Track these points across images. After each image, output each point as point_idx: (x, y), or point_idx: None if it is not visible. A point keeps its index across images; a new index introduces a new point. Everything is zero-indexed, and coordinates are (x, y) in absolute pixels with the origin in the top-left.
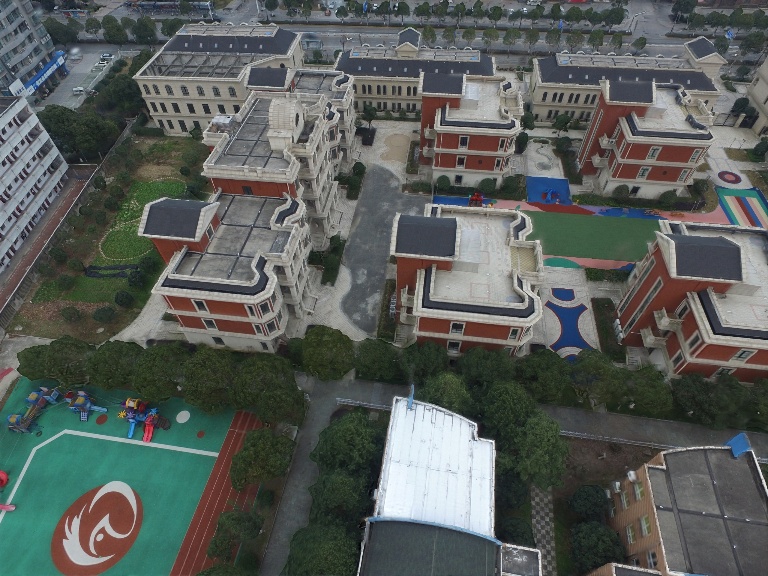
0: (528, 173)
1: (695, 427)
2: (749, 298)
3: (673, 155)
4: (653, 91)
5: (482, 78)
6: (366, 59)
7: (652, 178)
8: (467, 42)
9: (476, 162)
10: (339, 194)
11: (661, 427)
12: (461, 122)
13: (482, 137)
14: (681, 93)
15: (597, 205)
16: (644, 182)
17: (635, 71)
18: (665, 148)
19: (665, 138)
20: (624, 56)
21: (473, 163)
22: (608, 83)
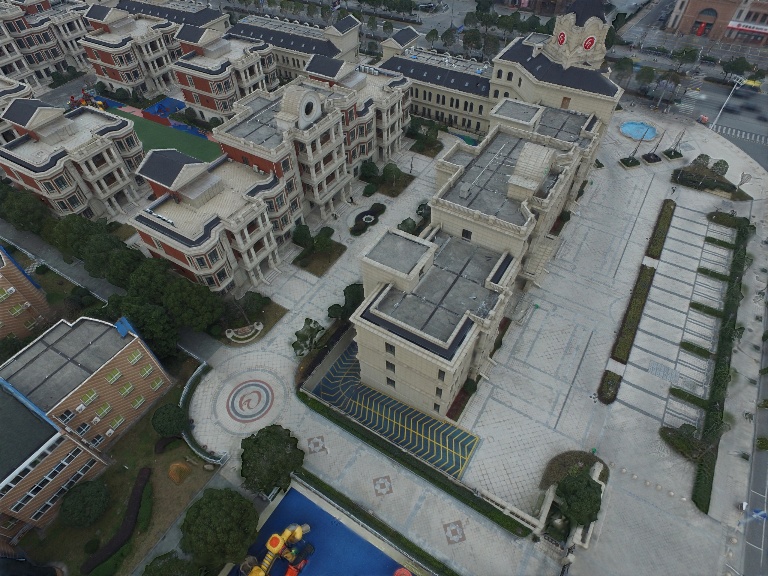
0: (173, 96)
1: (26, 231)
2: (48, 146)
3: (202, 85)
4: (203, 35)
5: (155, 18)
6: (133, 1)
7: (204, 105)
8: (271, 9)
9: (112, 73)
10: (48, 83)
11: (10, 226)
12: (92, 39)
13: (102, 52)
14: (258, 47)
15: (178, 121)
16: (201, 107)
17: (283, 34)
18: (193, 78)
19: (189, 69)
20: (292, 23)
21: (111, 74)
22: (182, 26)
